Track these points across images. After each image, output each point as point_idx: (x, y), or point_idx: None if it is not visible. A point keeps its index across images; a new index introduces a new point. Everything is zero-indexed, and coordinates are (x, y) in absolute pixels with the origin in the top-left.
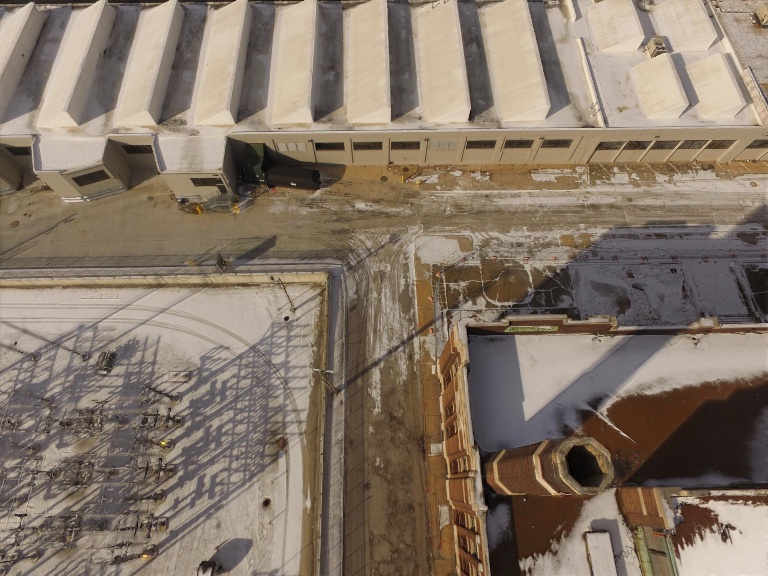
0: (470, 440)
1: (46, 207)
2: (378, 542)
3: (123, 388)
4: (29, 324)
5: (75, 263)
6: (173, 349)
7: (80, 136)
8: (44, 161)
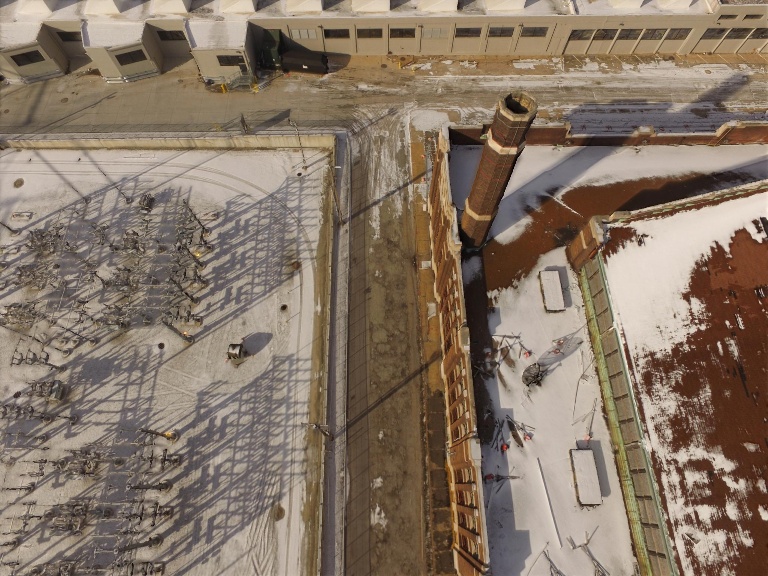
0: (449, 199)
1: (91, 87)
2: (377, 329)
3: (161, 224)
4: (80, 176)
5: (118, 129)
6: (203, 196)
7: (122, 21)
8: (92, 40)
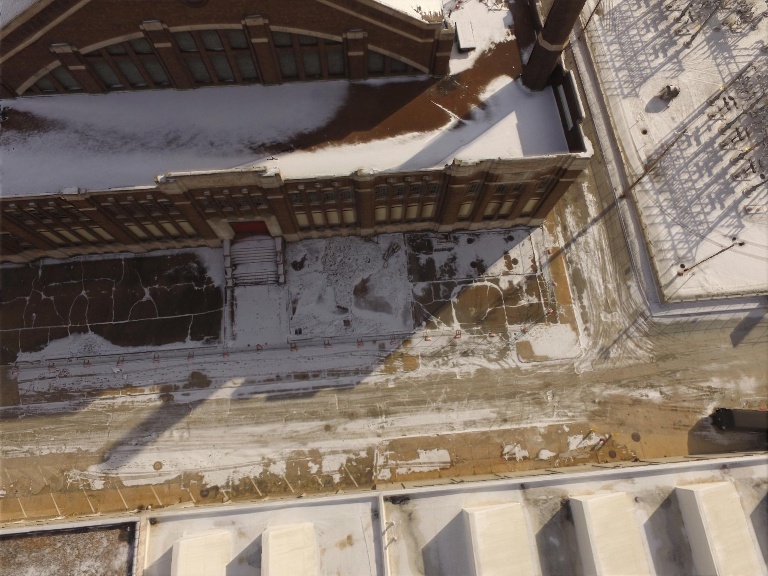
0: None
1: None
2: None
3: None
4: None
5: None
6: None
7: None
8: None
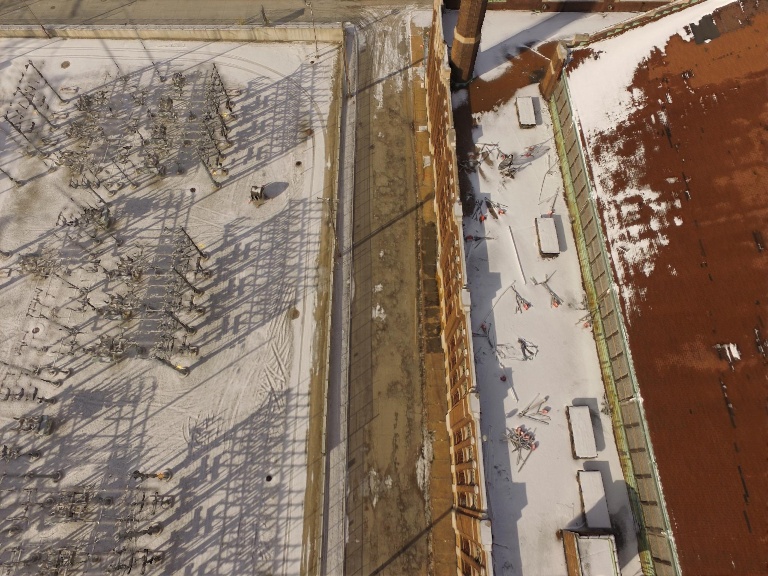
0: (441, 37)
1: None
2: (379, 176)
3: (191, 98)
4: (119, 60)
5: (152, 22)
6: (227, 77)
7: None
8: None
